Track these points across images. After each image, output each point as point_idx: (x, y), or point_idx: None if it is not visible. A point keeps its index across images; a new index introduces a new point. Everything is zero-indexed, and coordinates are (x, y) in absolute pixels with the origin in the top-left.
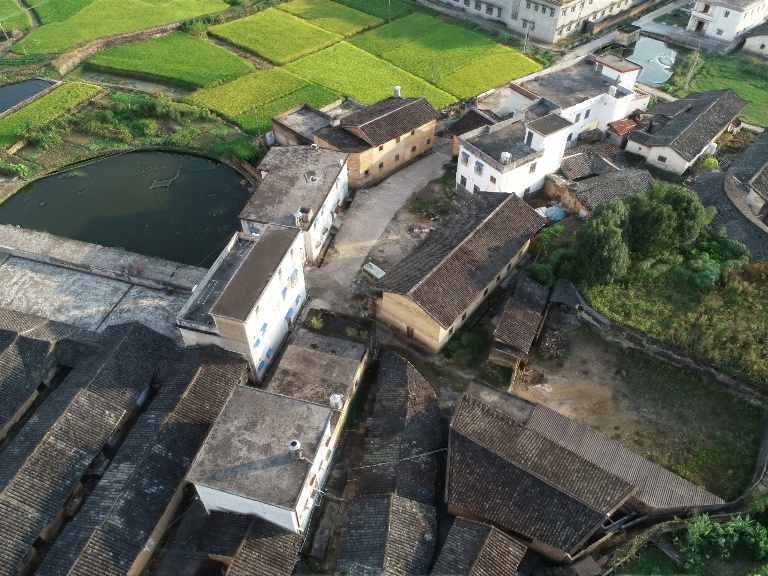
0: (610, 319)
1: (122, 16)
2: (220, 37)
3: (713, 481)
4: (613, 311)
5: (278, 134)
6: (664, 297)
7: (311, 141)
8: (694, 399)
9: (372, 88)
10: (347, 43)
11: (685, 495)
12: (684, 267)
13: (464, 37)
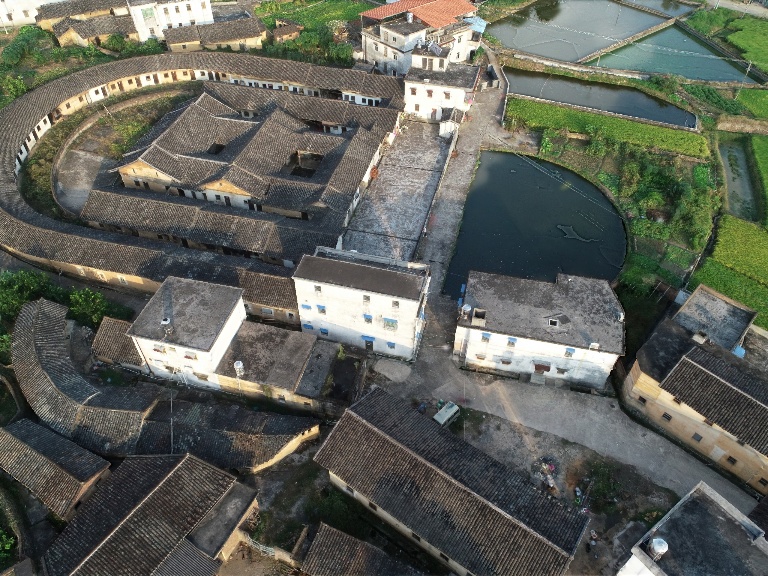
0: None
1: None
2: None
3: None
4: None
5: None
6: None
7: None
8: None
9: None
10: None
11: None
12: None
13: None
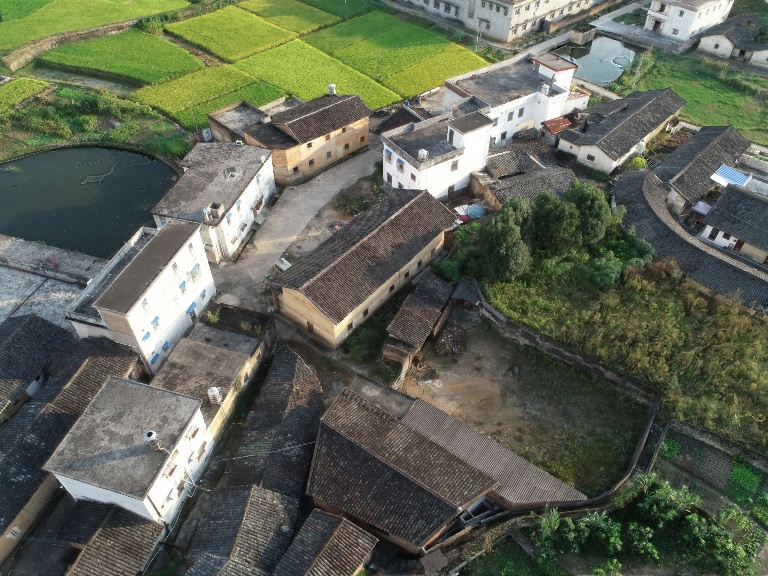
0: (506, 316)
1: (82, 13)
2: (175, 34)
3: (584, 477)
4: (511, 308)
5: (214, 131)
6: (564, 295)
7: (242, 138)
8: (581, 396)
9: (318, 86)
10: (300, 41)
11: (547, 491)
12: (589, 265)
13: (418, 35)
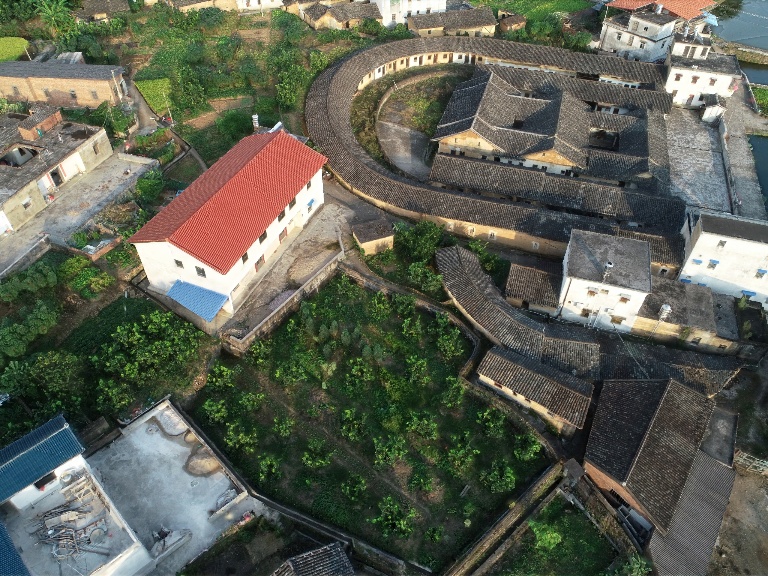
0: None
1: None
2: None
3: None
4: None
5: None
6: None
7: None
8: None
9: None
10: None
11: None
12: None
13: None
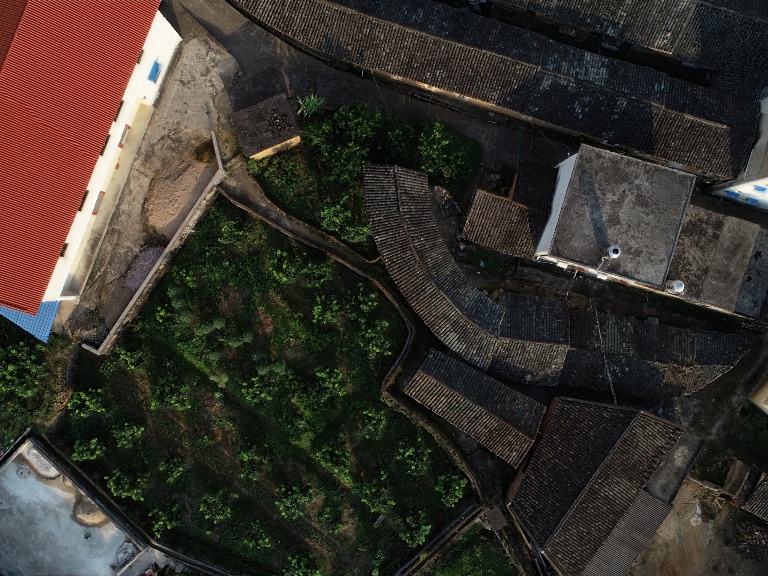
0: None
1: None
2: None
3: None
4: None
5: None
6: None
7: None
8: None
9: None
10: None
11: None
12: None
13: None
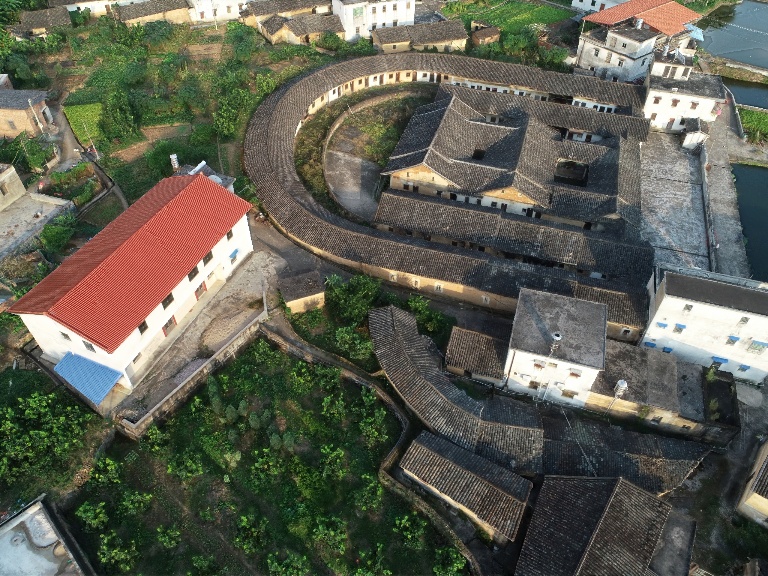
0: None
1: None
2: None
3: None
4: None
5: None
6: None
7: None
8: None
9: None
10: None
11: None
12: None
13: None
